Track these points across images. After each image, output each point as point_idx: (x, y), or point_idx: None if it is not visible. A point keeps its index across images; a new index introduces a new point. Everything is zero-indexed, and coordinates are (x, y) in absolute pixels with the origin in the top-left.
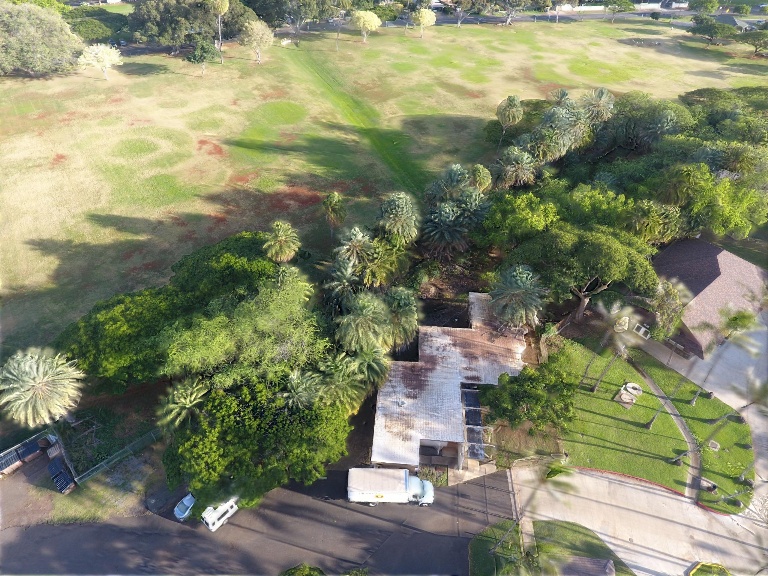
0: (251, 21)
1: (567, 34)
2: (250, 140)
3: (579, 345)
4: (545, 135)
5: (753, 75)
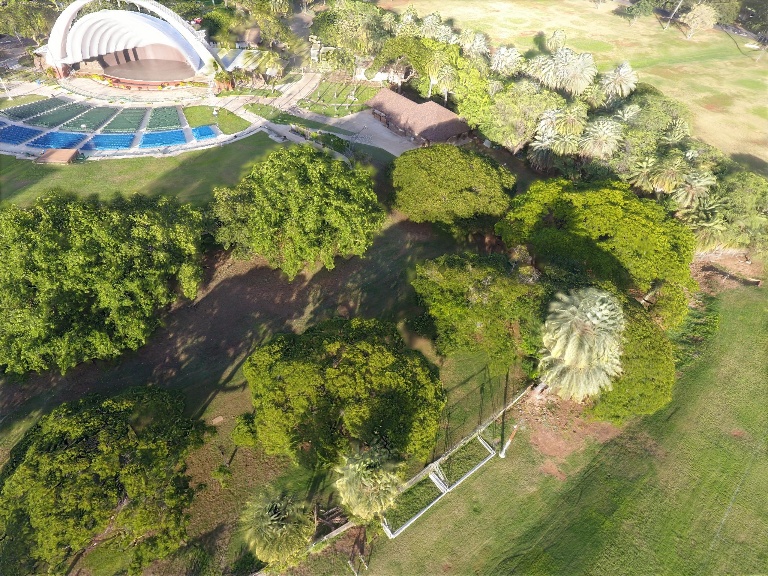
0: (703, 4)
1: None
2: (545, 40)
3: None
4: None
5: None
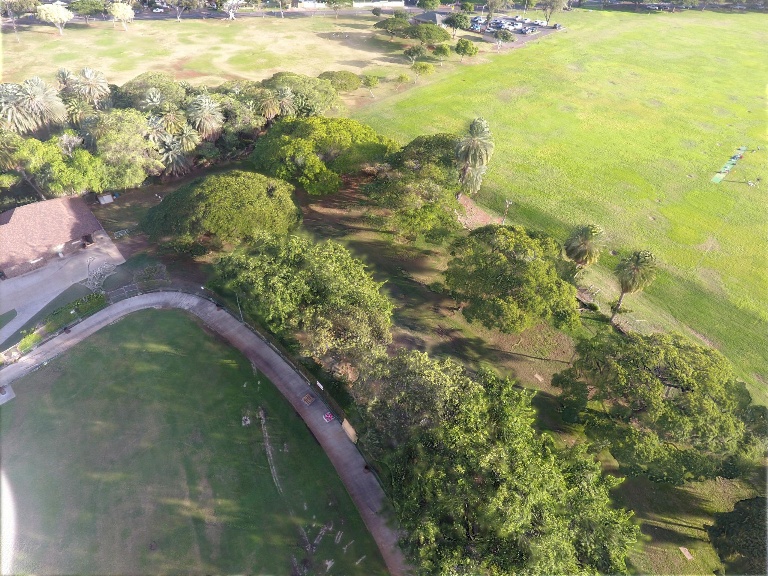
0: None
1: (277, 28)
2: None
3: None
4: None
5: (398, 64)
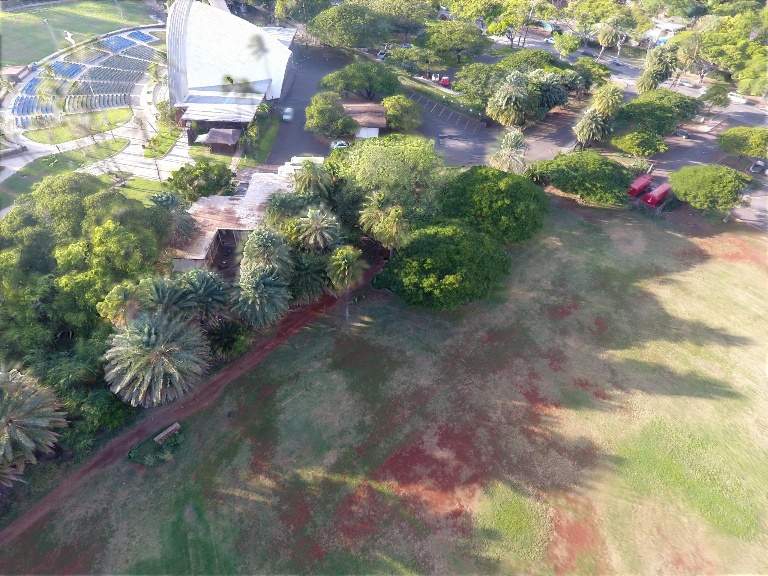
0: None
1: None
2: None
3: None
4: None
5: None
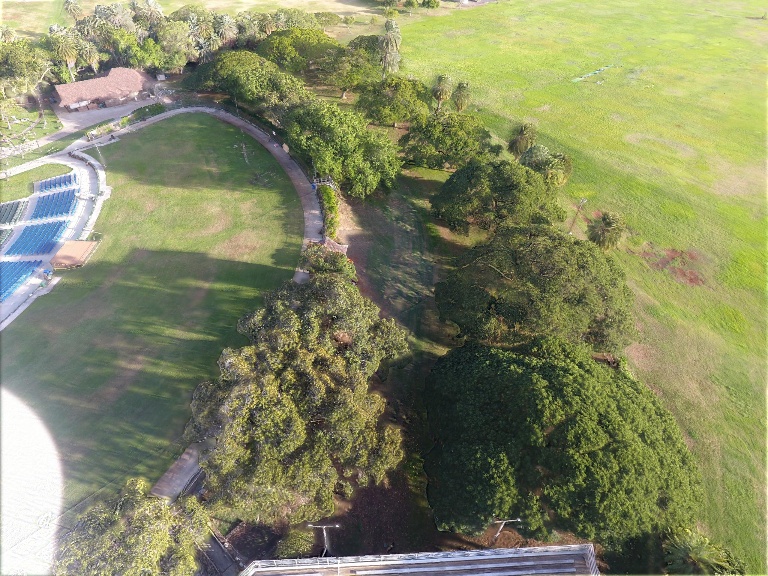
0: None
1: None
2: None
3: (23, 109)
4: (85, 20)
5: (376, 14)
